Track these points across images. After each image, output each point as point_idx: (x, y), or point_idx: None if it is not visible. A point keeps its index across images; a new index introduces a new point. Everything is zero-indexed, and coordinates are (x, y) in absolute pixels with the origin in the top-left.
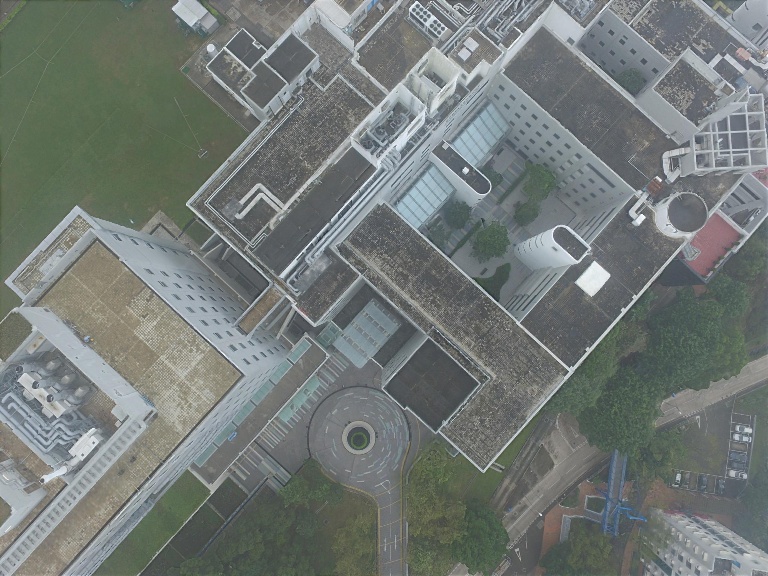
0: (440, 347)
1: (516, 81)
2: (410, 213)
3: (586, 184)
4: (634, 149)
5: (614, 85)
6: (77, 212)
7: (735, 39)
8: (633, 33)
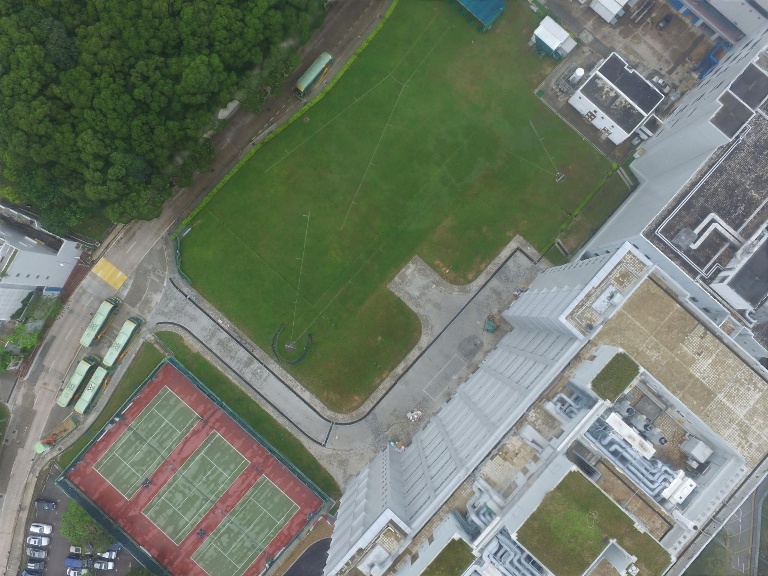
0: None
1: None
2: None
3: None
4: None
5: None
6: (628, 248)
7: None
8: None
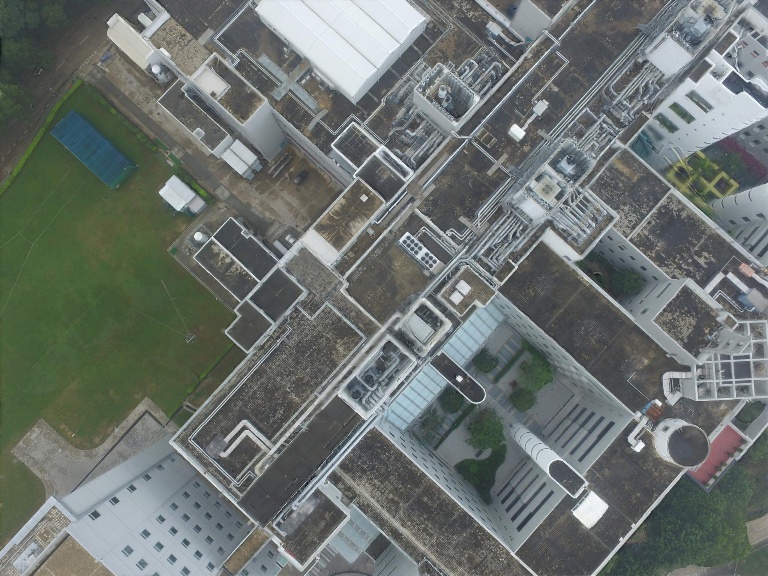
0: None
1: (511, 296)
2: (403, 409)
3: (584, 383)
4: (633, 367)
5: (612, 301)
6: (52, 503)
7: (738, 251)
8: (632, 247)
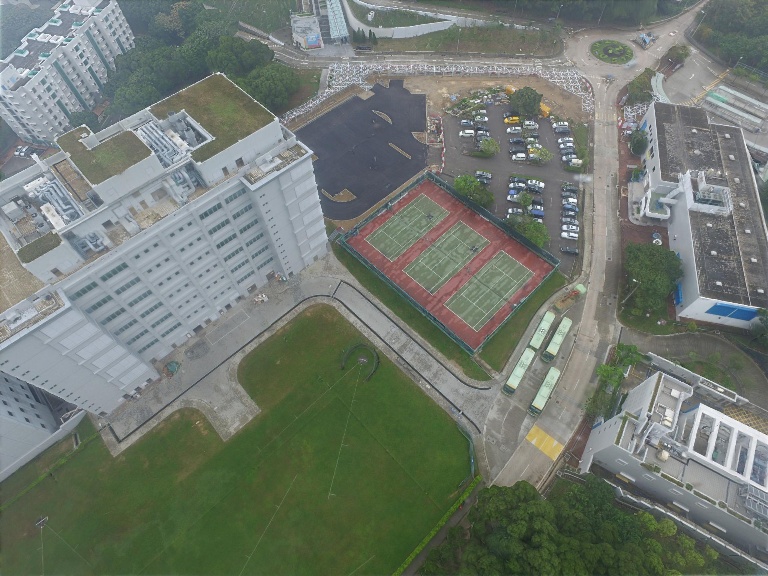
0: None
1: None
2: None
3: None
4: None
5: None
6: None
7: None
8: None
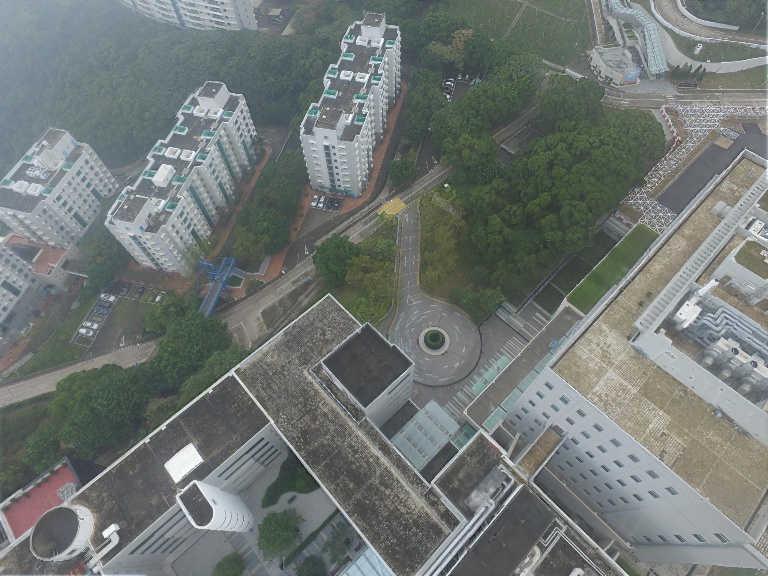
0: (355, 399)
1: None
2: None
3: None
4: None
5: None
6: None
7: None
8: None
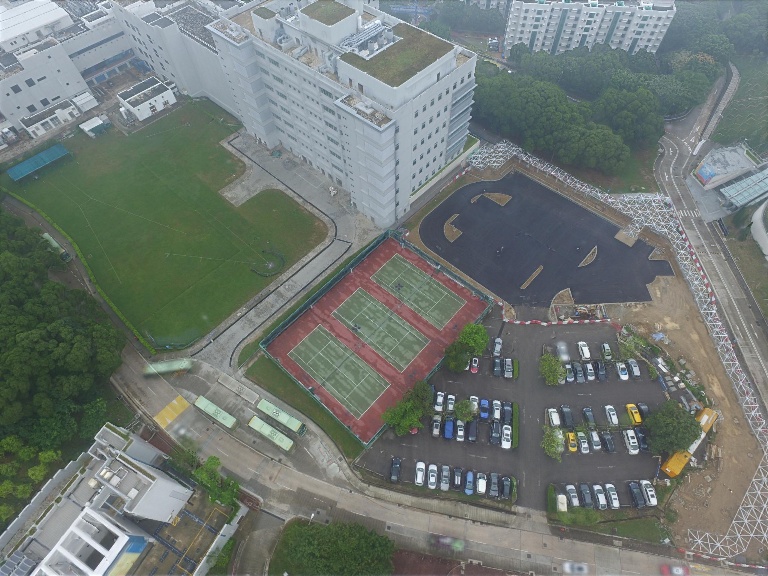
0: None
1: None
2: None
3: None
4: None
5: None
6: (208, 26)
7: None
8: None
